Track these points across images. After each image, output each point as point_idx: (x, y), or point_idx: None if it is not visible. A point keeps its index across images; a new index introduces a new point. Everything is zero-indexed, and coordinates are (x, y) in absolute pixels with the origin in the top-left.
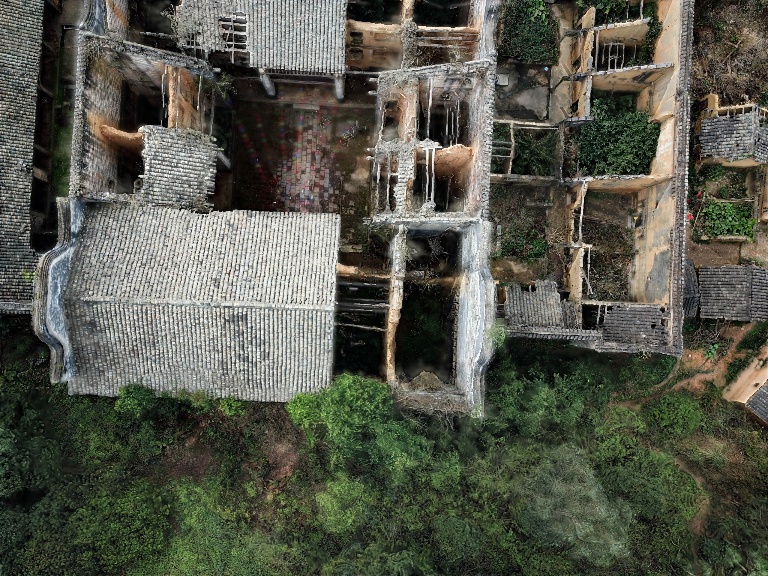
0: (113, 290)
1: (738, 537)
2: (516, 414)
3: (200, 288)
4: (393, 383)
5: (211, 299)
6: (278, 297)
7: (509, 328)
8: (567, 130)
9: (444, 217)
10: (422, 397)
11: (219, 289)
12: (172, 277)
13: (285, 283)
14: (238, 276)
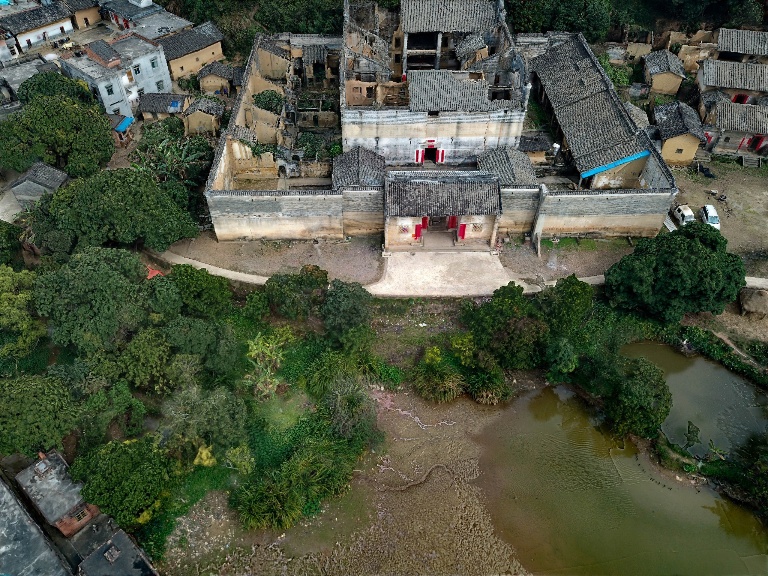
0: (480, 2)
1: (241, 3)
2: (325, 23)
3: (450, 4)
4: (376, 5)
5: (445, 0)
6: (421, 2)
7: (328, 36)
8: (288, 128)
9: (360, 28)
10: (365, 5)
11: (443, 4)
12: (461, 7)
13: (419, 6)
14: (437, 8)
